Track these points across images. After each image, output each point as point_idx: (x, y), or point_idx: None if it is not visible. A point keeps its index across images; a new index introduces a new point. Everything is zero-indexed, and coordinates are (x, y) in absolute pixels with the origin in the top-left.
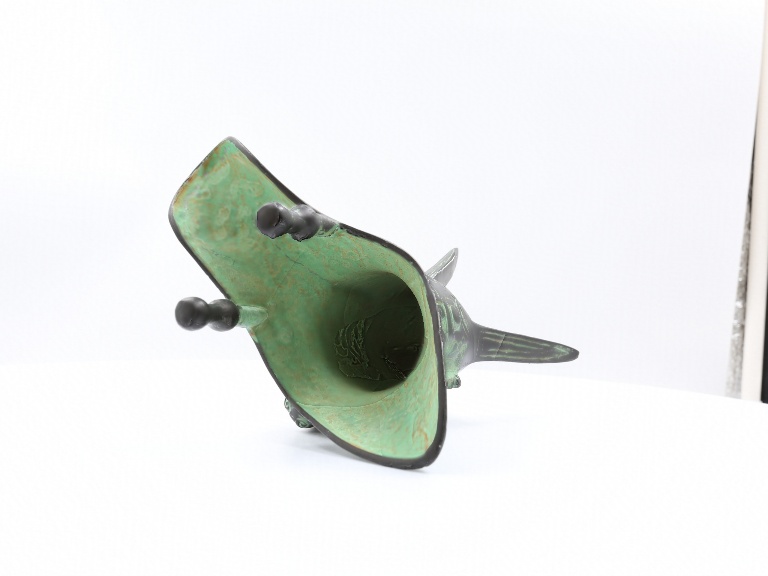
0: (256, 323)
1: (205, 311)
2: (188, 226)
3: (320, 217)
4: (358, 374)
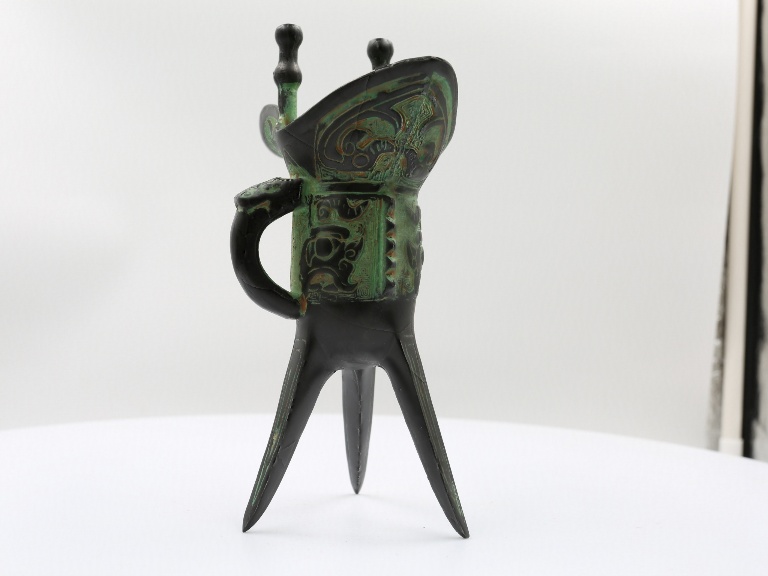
0: (291, 117)
1: None
2: None
3: None
4: (293, 267)
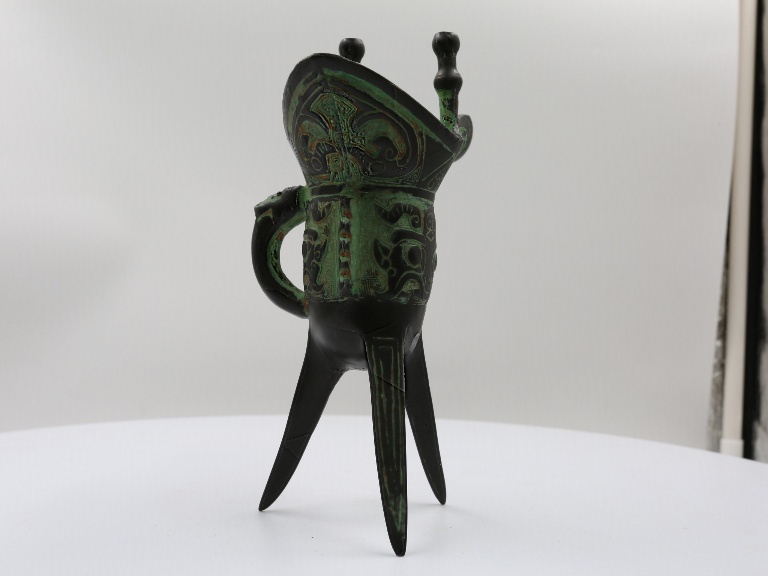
0: None
1: (358, 46)
2: None
3: None
4: None
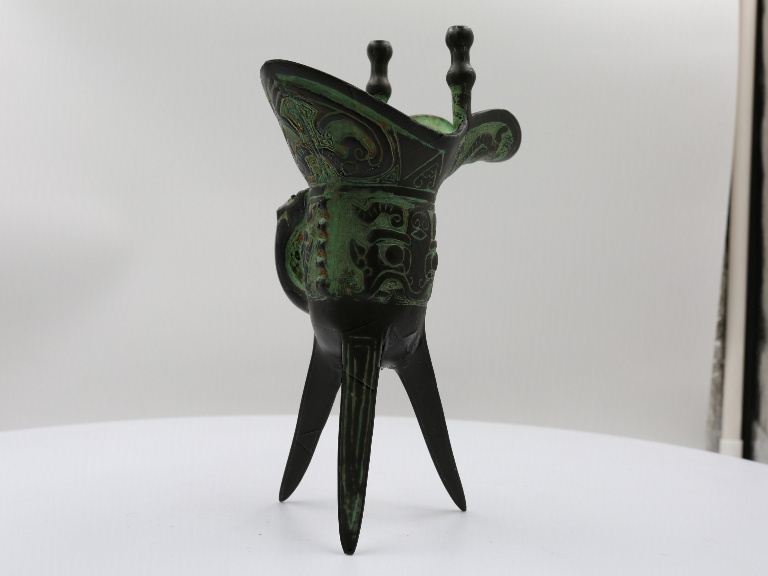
0: None
1: (383, 48)
2: (444, 129)
3: (469, 92)
4: None
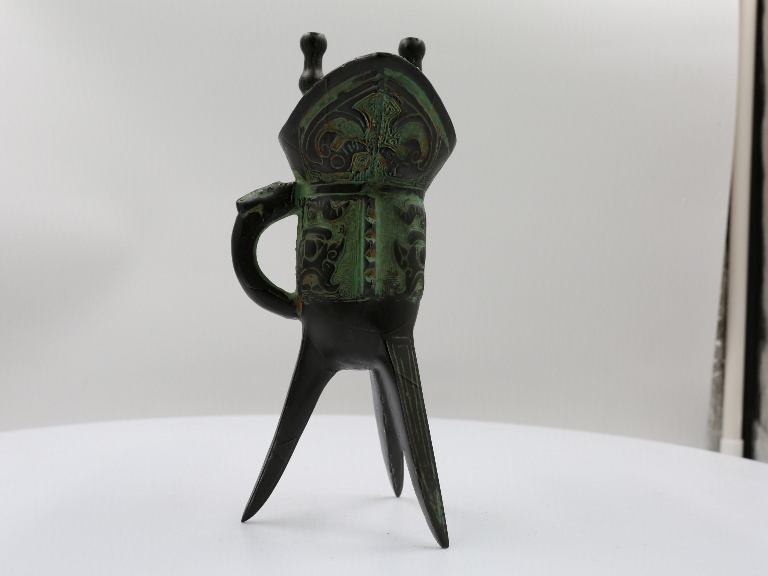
0: None
1: (324, 42)
2: None
3: None
4: None
